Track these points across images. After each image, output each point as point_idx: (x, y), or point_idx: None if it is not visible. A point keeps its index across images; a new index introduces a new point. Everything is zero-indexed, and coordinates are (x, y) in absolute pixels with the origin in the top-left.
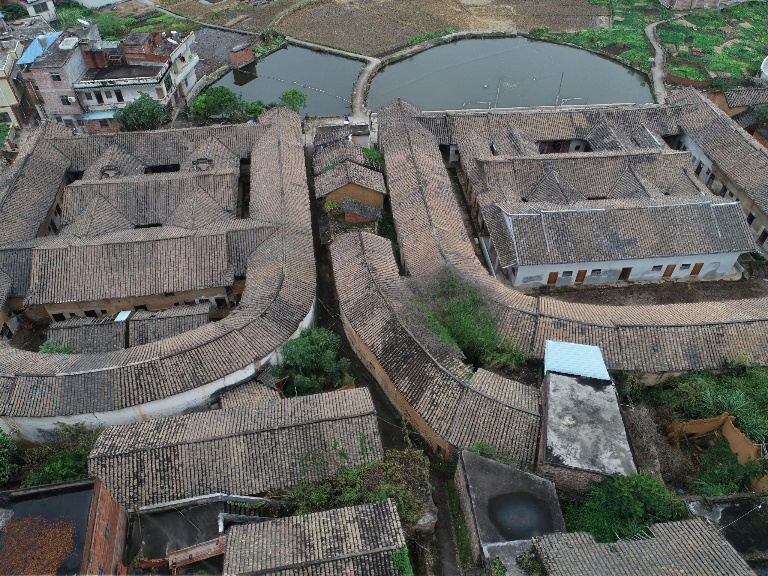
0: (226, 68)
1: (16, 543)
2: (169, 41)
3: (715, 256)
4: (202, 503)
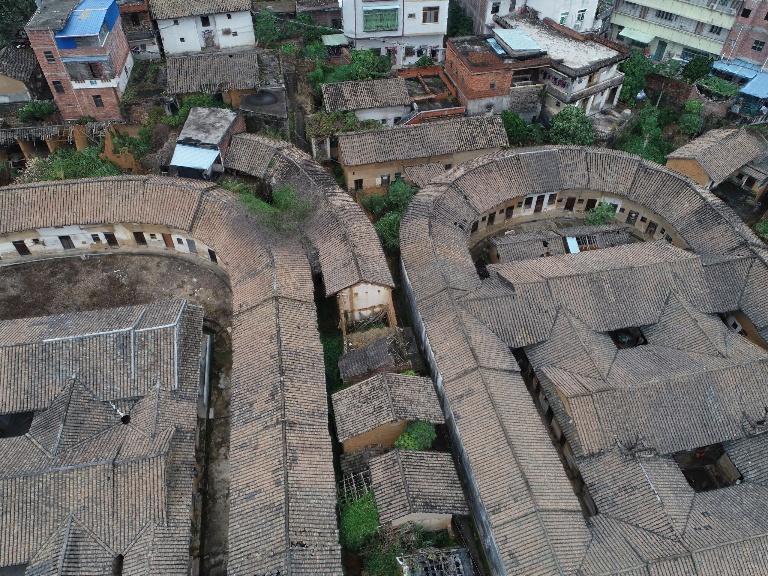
0: None
1: None
2: None
3: None
4: (430, 116)
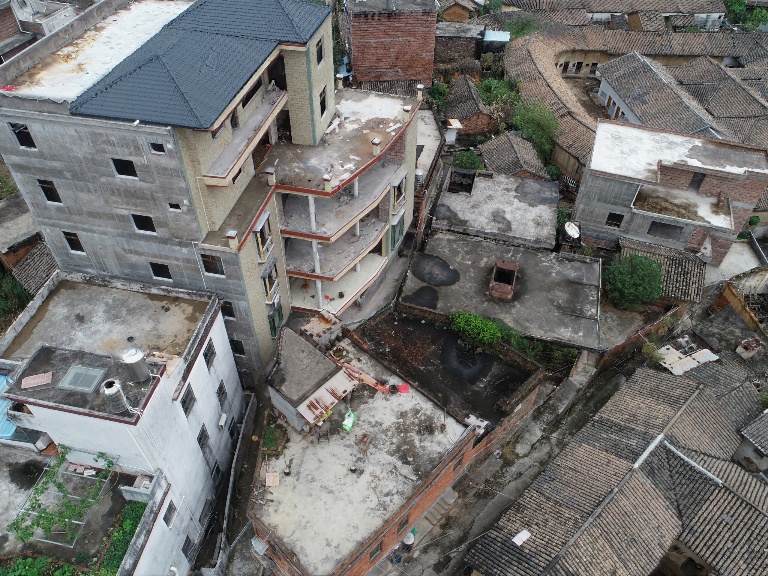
0: None
1: None
2: None
3: None
4: None
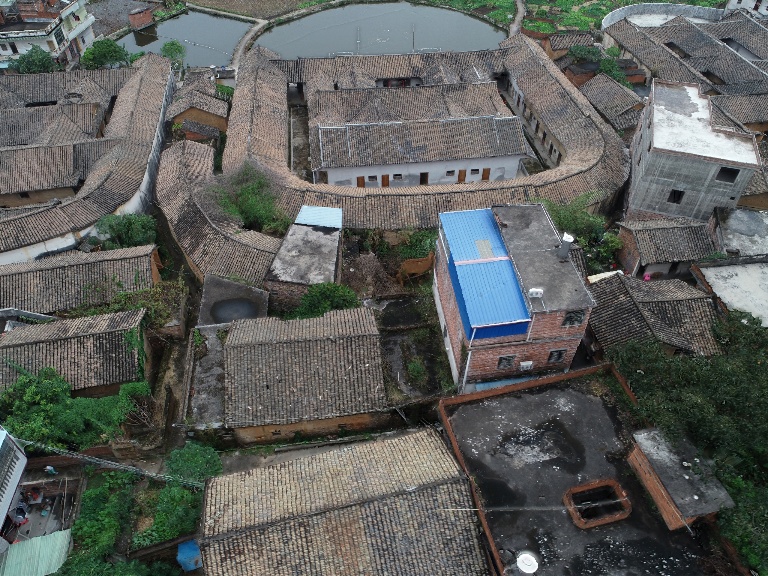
0: (126, 30)
1: None
2: (62, 1)
3: (498, 161)
4: None
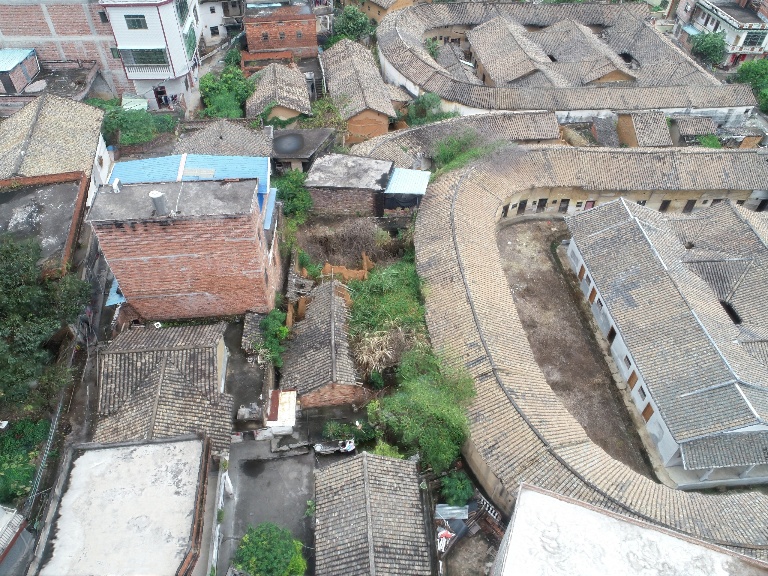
0: None
1: (290, 8)
2: None
3: None
4: None
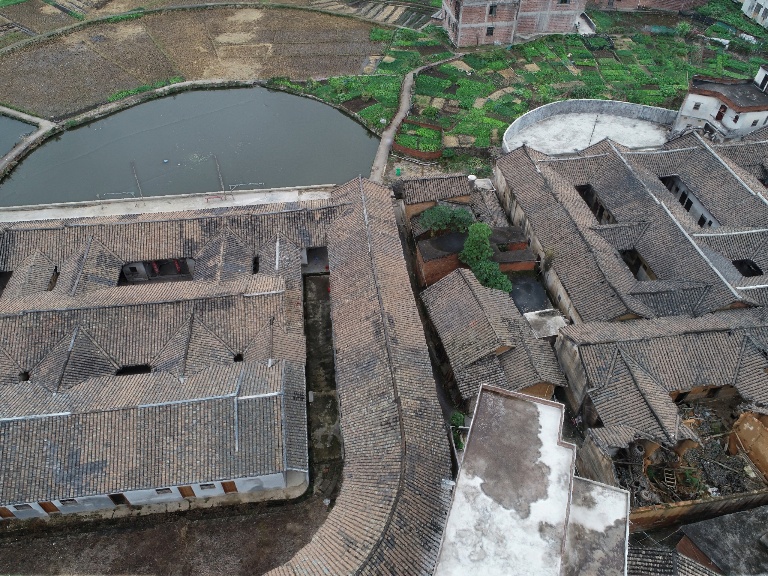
0: None
1: None
2: None
3: None
4: None
